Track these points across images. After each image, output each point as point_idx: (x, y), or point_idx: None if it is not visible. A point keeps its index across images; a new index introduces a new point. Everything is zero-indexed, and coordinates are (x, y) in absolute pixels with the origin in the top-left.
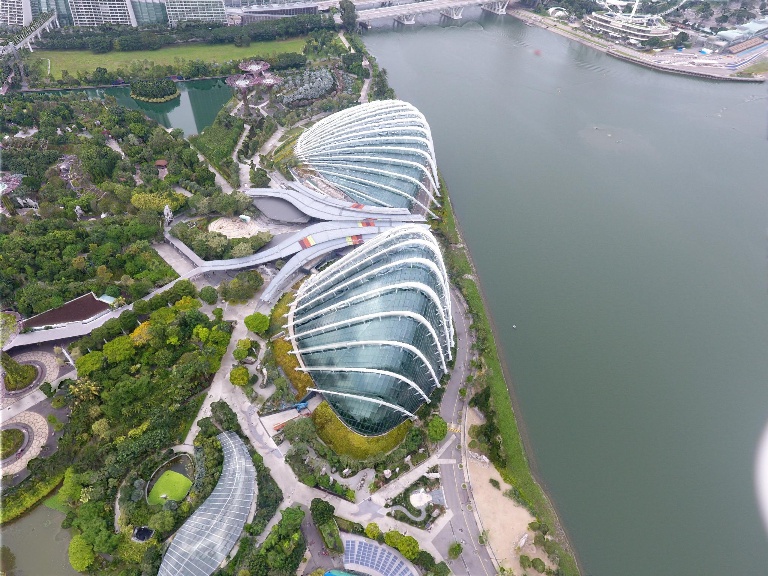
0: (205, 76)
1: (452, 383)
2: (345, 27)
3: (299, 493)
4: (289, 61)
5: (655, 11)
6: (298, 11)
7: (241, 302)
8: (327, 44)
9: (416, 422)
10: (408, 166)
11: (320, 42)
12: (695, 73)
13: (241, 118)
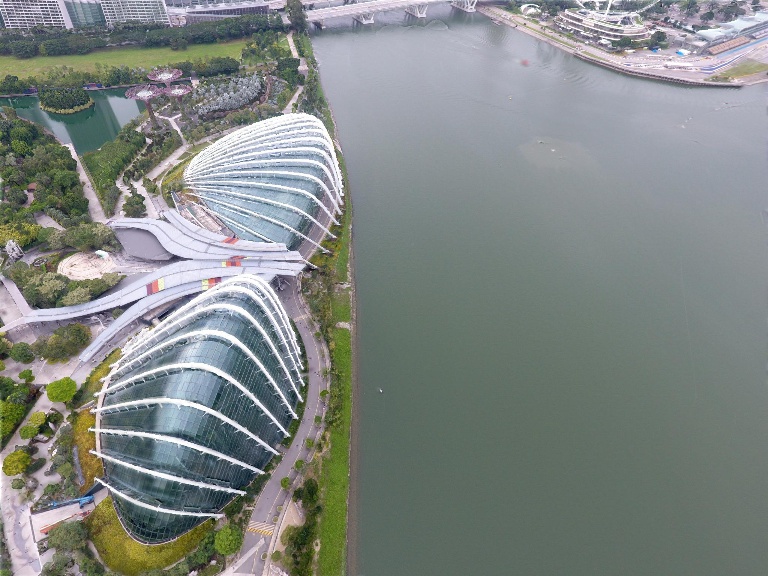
0: (127, 83)
1: (282, 467)
2: None
3: None
4: (219, 67)
5: (635, 8)
6: (247, 11)
7: (61, 360)
8: (267, 47)
9: (222, 521)
10: (296, 193)
11: (260, 45)
12: (666, 77)
13: (145, 132)
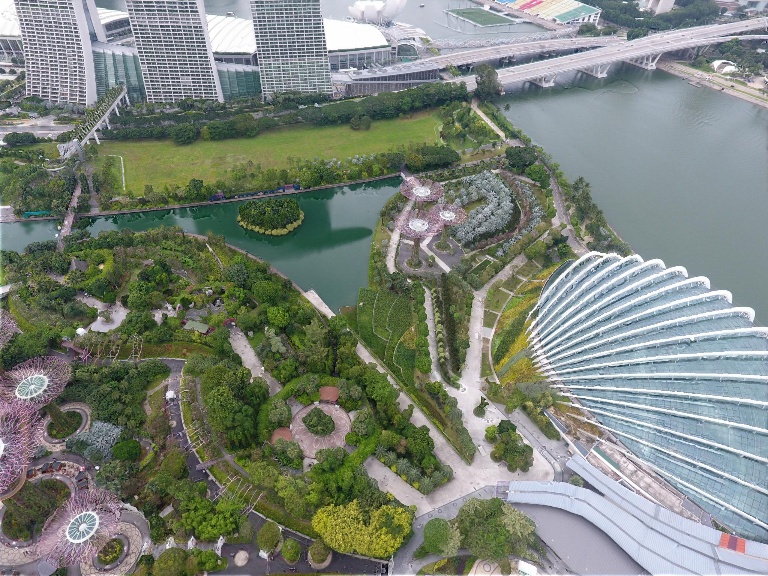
0: (329, 183)
1: None
2: (477, 95)
3: None
4: (437, 159)
5: None
6: (416, 75)
7: None
8: (473, 127)
9: None
10: None
11: (462, 124)
12: None
13: (412, 274)
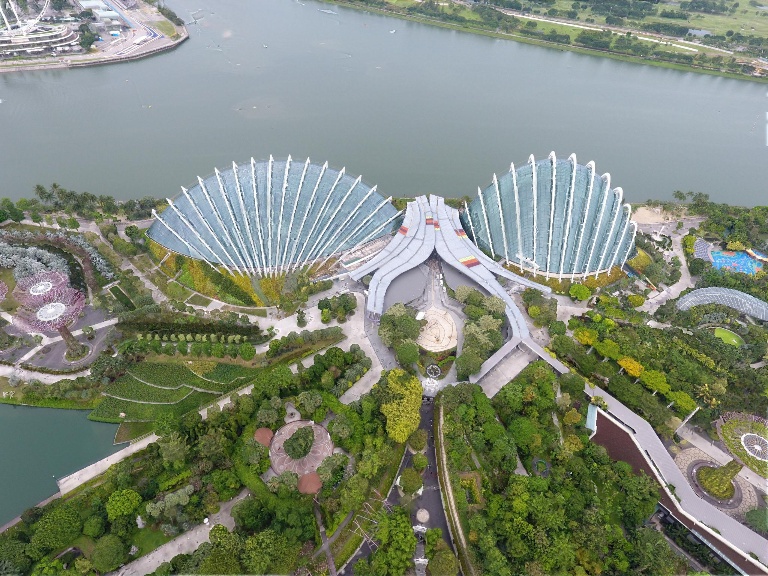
0: None
1: None
2: None
3: (685, 282)
4: None
5: None
6: None
7: None
8: None
9: None
10: None
11: None
12: (158, 49)
13: None
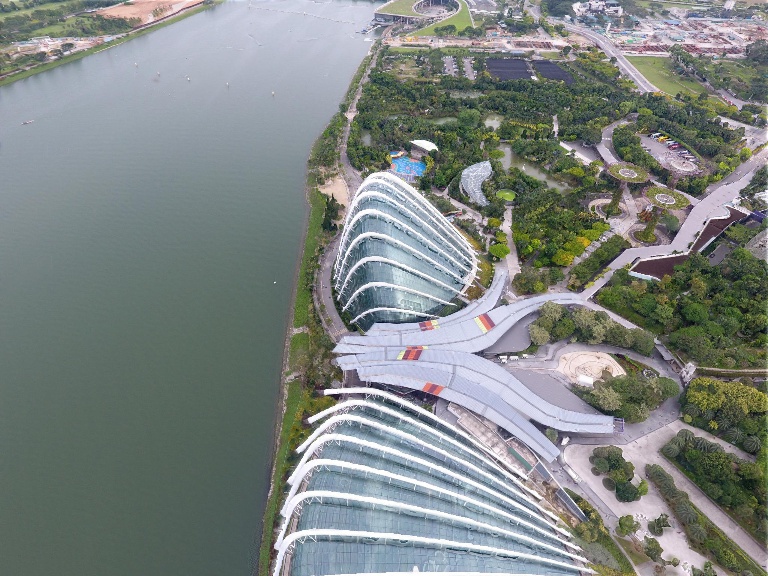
0: None
1: None
2: None
3: None
4: None
5: None
6: None
7: None
8: None
9: None
10: None
11: None
12: None
13: None
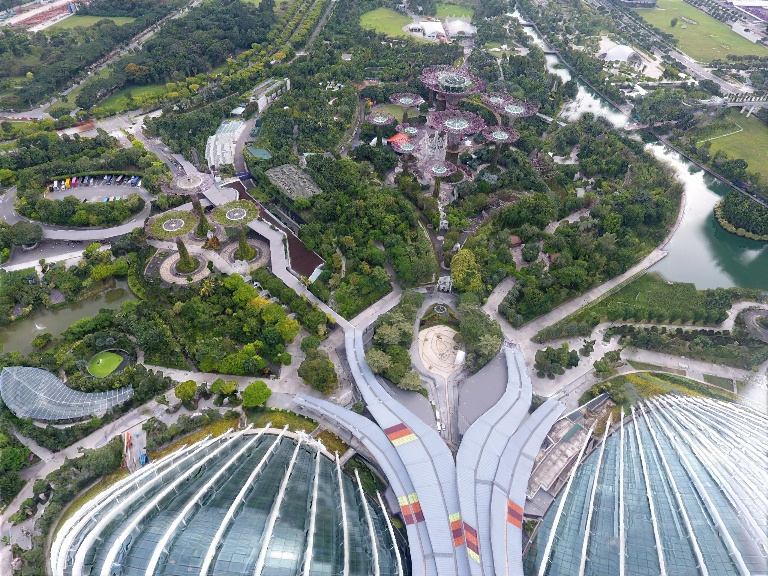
0: None
1: None
2: None
3: (52, 467)
4: None
5: None
6: None
7: None
8: None
9: None
10: None
11: None
12: None
13: (740, 315)
